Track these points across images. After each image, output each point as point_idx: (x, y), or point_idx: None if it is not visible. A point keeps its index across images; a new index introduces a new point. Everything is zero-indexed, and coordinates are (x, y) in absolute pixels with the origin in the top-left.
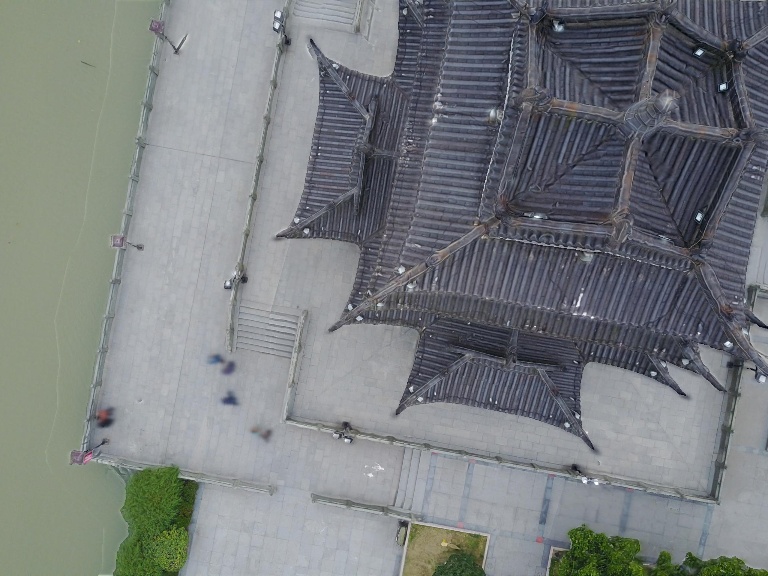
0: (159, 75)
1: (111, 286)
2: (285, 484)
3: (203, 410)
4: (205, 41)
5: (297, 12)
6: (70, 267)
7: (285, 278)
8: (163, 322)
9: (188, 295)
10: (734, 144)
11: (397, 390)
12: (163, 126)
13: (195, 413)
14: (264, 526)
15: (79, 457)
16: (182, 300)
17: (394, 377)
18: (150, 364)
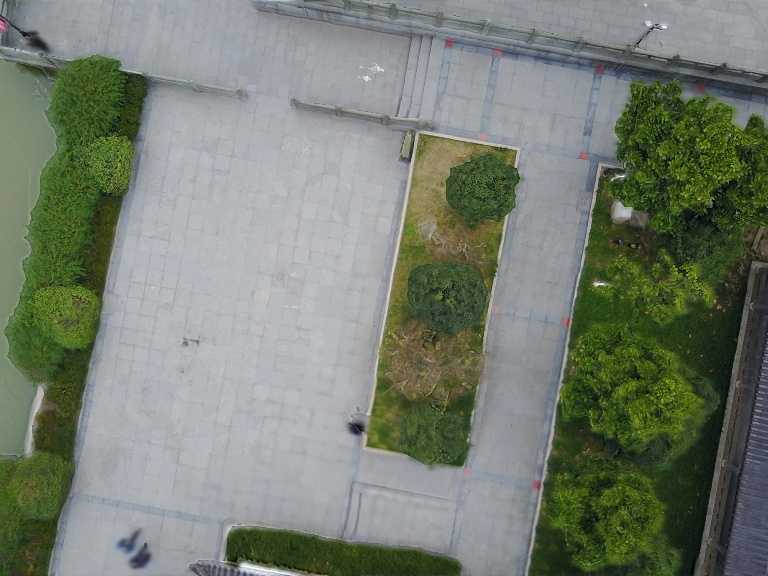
0: None
1: None
2: (257, 90)
3: None
4: None
5: None
6: None
7: None
8: None
9: None
10: None
11: None
12: None
13: None
14: (231, 144)
15: None
16: None
17: None
18: None
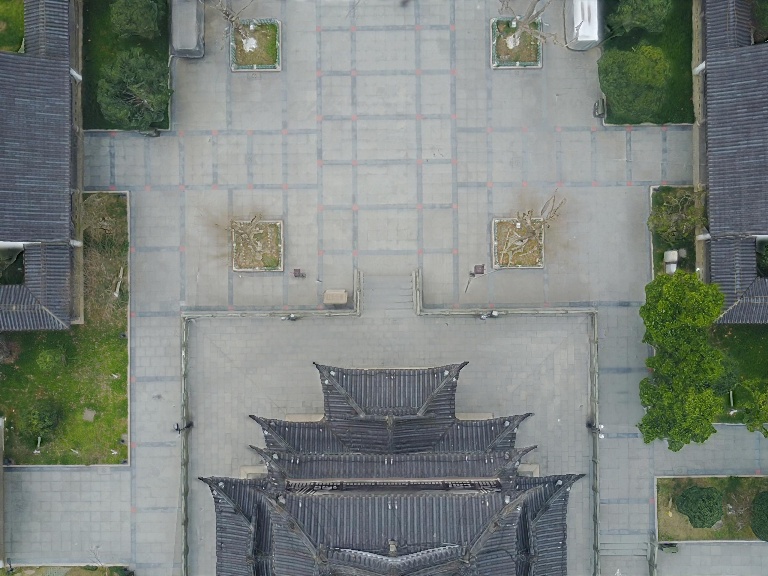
0: None
1: None
2: None
3: None
4: None
5: None
6: None
7: None
8: None
9: None
10: None
11: None
12: None
13: None
14: None
15: None
16: None
17: None
18: None
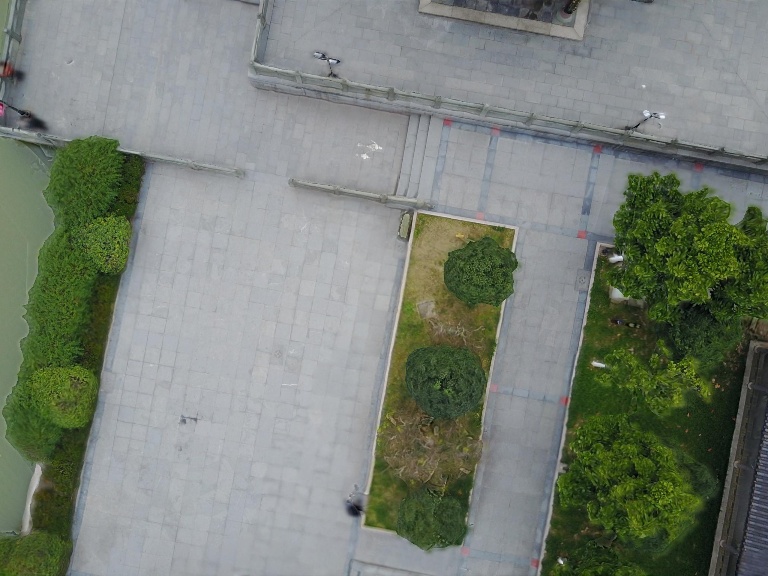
0: None
1: None
2: (255, 168)
3: (150, 74)
4: None
5: None
6: None
7: None
8: None
9: None
10: None
11: (398, 33)
12: None
13: (140, 78)
14: (229, 222)
15: None
16: None
17: (394, 16)
18: (83, 15)
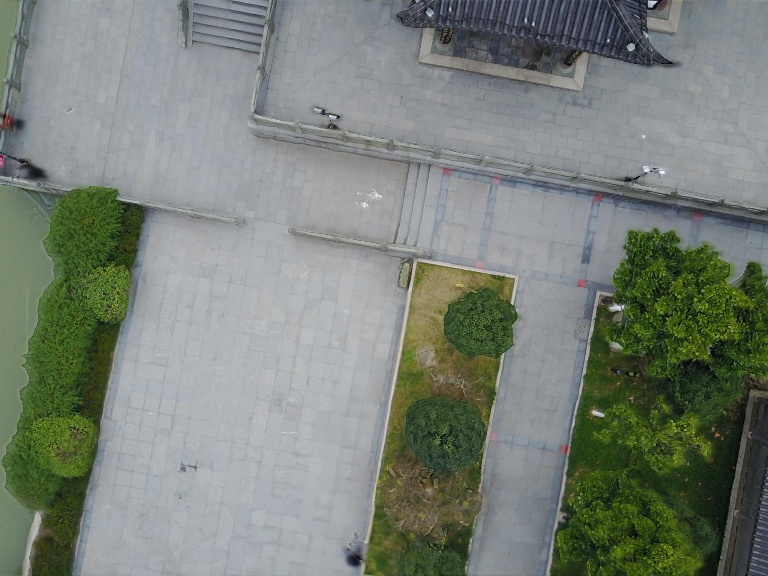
0: None
1: None
2: (255, 216)
3: (150, 122)
4: None
5: None
6: None
7: None
8: (99, 9)
9: None
10: None
11: (398, 83)
12: None
13: (140, 126)
14: (228, 270)
15: None
16: None
17: (394, 66)
18: (82, 63)
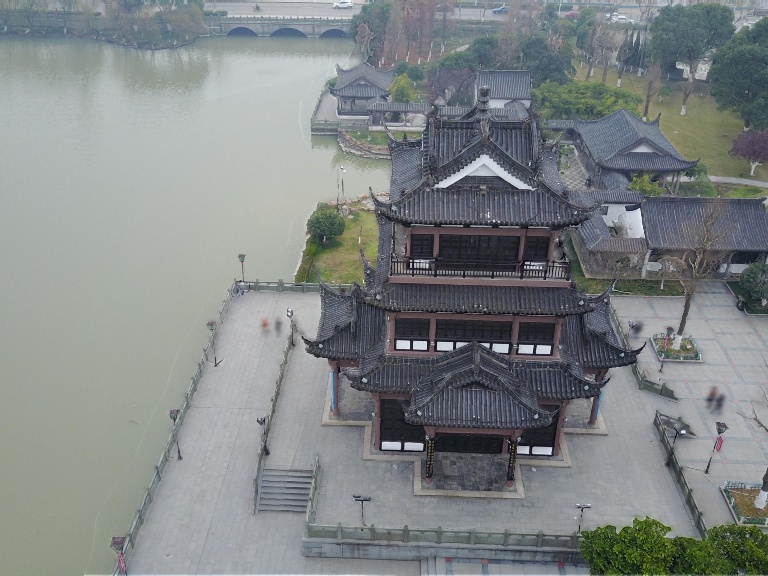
0: (203, 376)
1: (155, 471)
2: None
3: (228, 557)
4: (236, 360)
5: (298, 336)
6: (116, 486)
7: (300, 450)
8: (195, 501)
9: (218, 482)
10: (528, 127)
11: (403, 507)
12: (204, 398)
13: (220, 560)
14: None
15: (120, 538)
16: (212, 486)
17: (399, 499)
18: (181, 529)
